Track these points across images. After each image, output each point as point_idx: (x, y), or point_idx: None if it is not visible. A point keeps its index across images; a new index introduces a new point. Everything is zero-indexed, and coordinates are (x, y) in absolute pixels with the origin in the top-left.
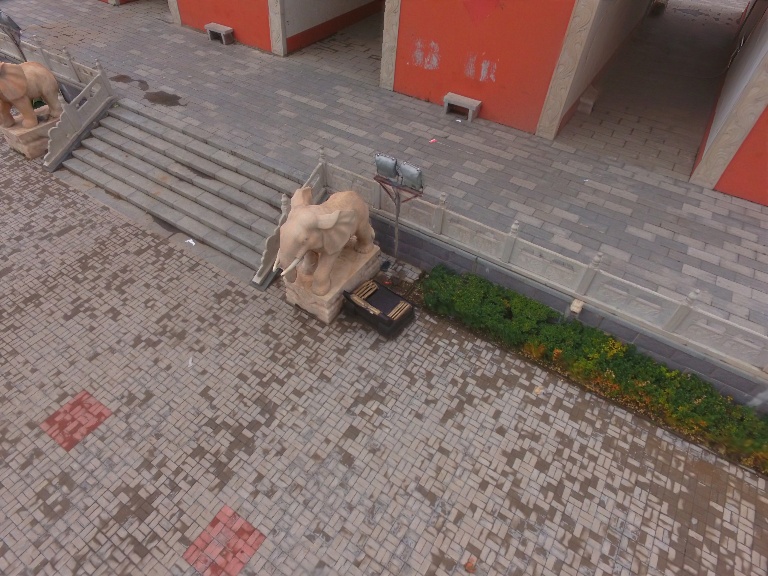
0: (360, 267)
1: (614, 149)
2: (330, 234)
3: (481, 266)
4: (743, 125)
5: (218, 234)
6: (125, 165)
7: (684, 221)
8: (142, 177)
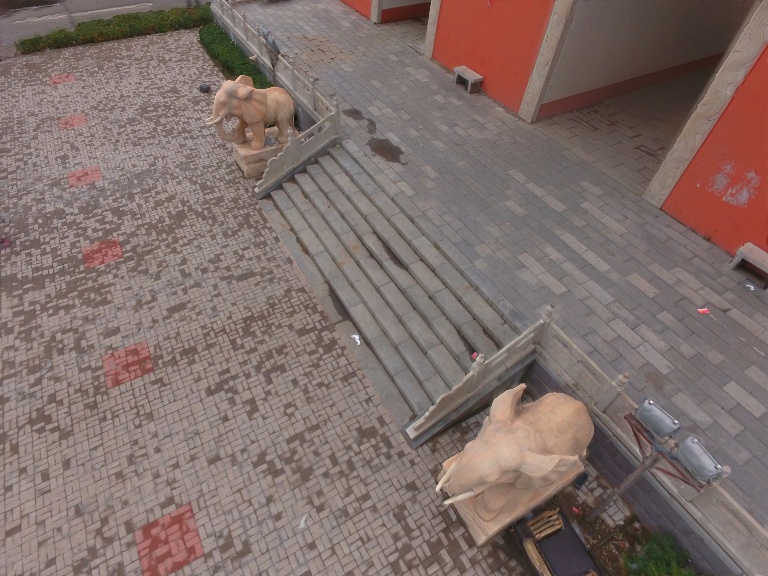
0: (549, 491)
1: None
2: (531, 477)
3: None
4: None
5: (388, 343)
6: (324, 217)
7: None
8: (335, 237)
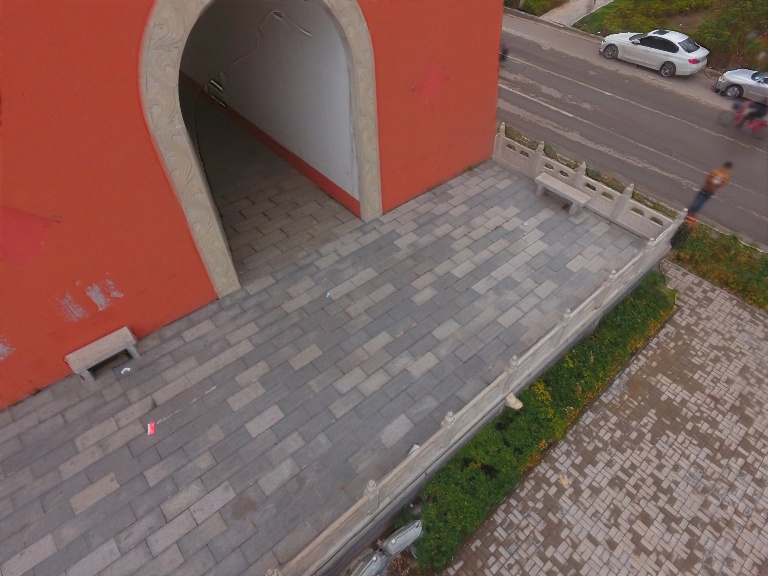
0: None
1: (288, 245)
2: None
3: (431, 472)
4: (373, 161)
5: None
6: None
7: (418, 256)
8: None
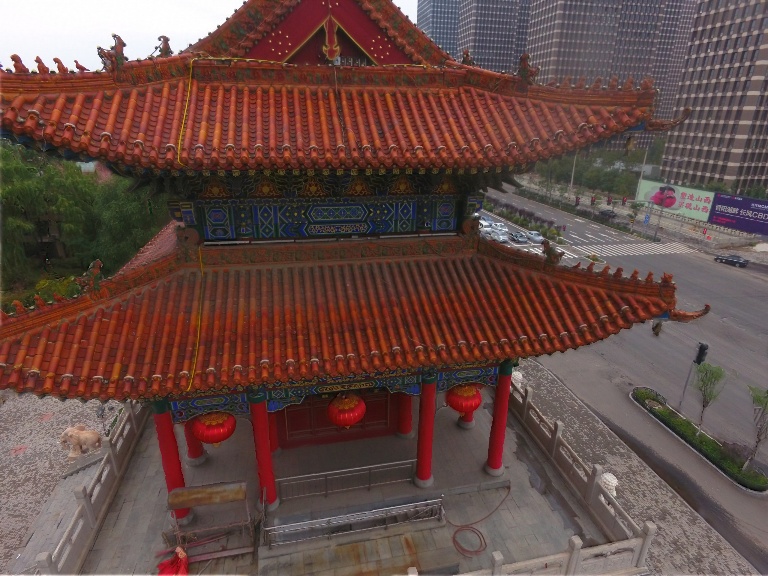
0: None
1: None
2: None
3: None
4: None
5: None
6: None
7: None
8: None
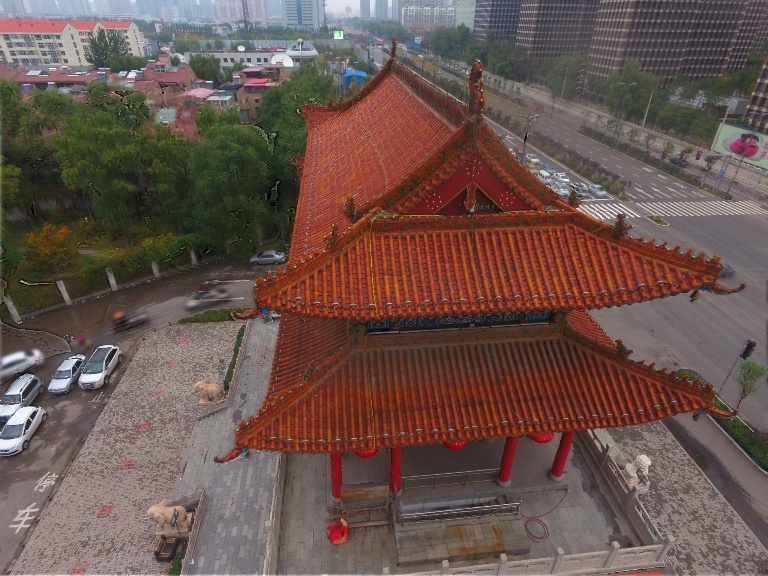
0: (175, 532)
1: None
2: (157, 518)
3: None
4: None
5: None
6: None
7: None
8: None
